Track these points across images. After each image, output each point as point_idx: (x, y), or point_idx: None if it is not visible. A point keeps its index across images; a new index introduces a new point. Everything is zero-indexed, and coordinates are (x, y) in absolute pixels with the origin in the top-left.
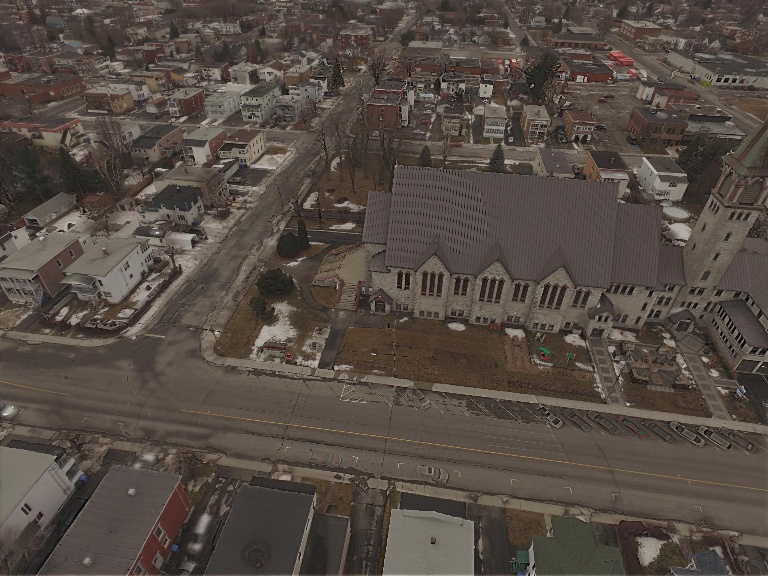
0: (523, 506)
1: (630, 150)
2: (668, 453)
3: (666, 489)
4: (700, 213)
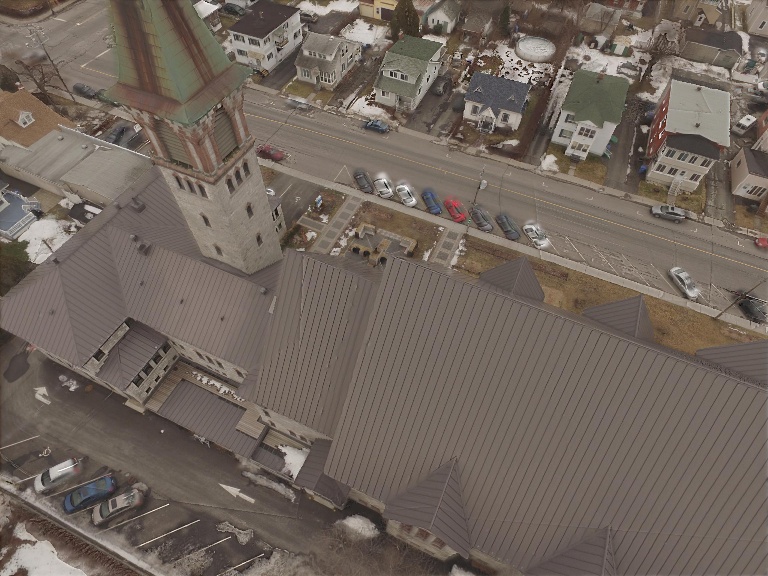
0: (588, 183)
1: None
2: (440, 187)
3: (464, 169)
4: None
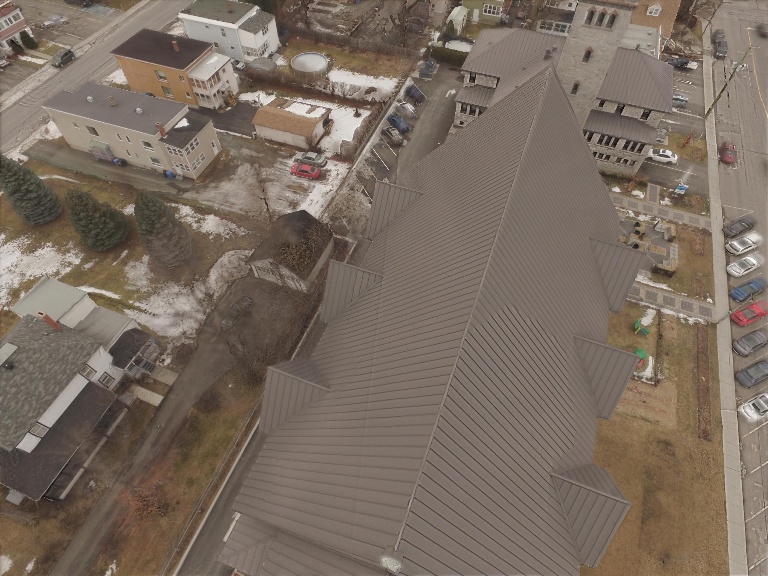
0: None
1: (102, 17)
2: None
3: None
4: (315, 46)
